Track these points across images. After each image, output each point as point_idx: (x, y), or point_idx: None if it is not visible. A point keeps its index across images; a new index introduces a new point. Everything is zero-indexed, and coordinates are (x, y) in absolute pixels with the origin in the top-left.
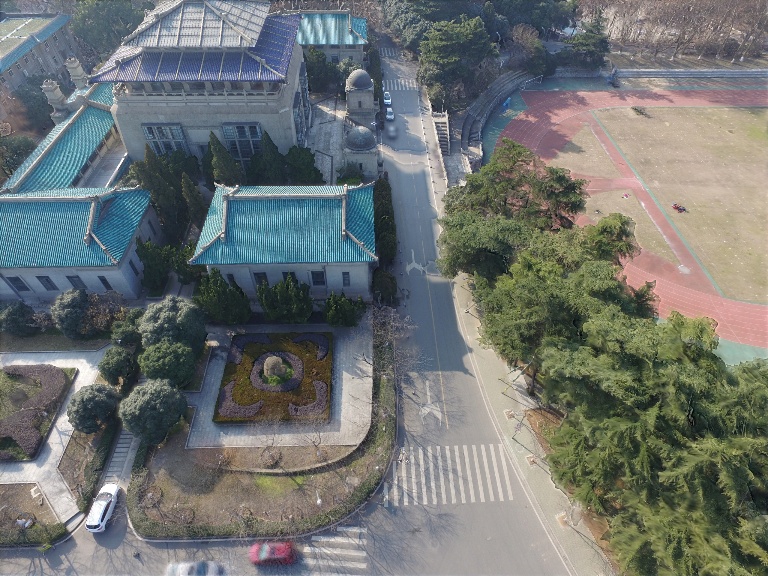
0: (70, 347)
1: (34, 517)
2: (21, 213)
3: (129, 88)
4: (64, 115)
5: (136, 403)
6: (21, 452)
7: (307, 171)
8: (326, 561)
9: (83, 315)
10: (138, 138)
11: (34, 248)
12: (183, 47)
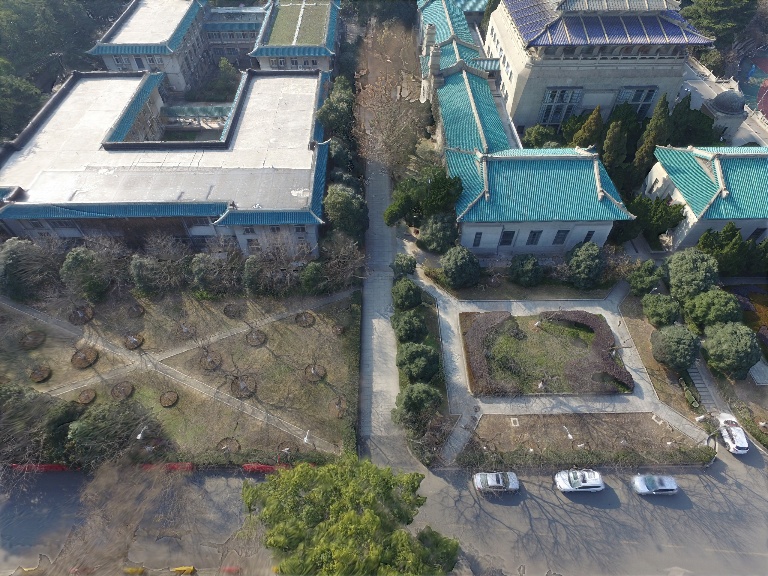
0: (578, 296)
1: (675, 440)
2: (530, 170)
3: (541, 52)
4: None
5: (745, 341)
6: (619, 386)
7: (710, 133)
8: None
9: (605, 266)
10: (532, 102)
11: (552, 203)
12: (609, 11)
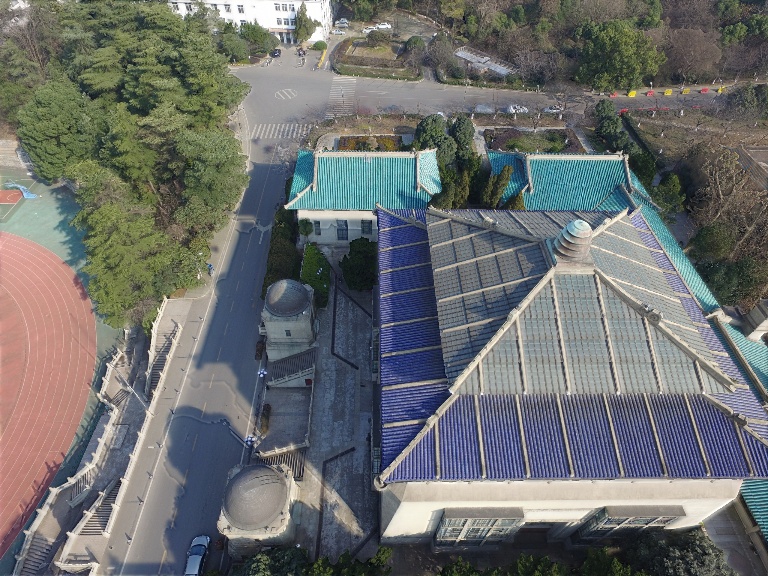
0: None
1: None
2: None
3: None
4: (724, 312)
5: None
6: None
7: None
8: (343, 113)
9: None
10: None
11: None
12: None
